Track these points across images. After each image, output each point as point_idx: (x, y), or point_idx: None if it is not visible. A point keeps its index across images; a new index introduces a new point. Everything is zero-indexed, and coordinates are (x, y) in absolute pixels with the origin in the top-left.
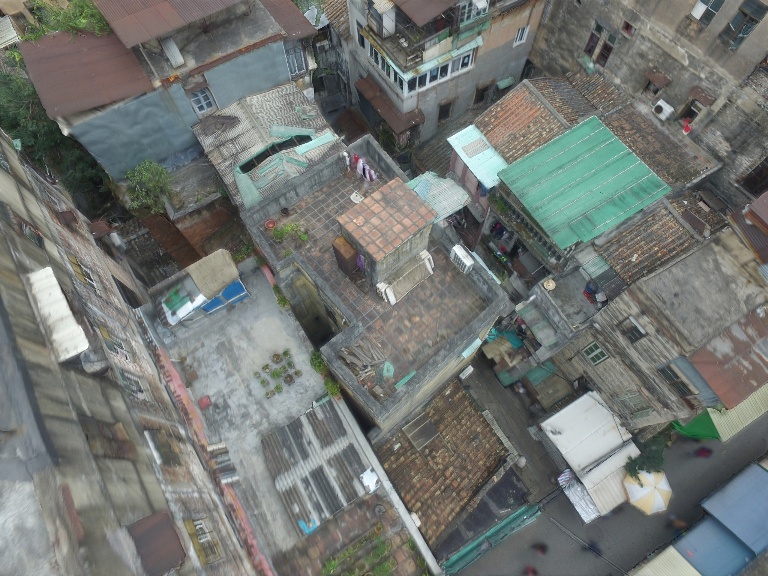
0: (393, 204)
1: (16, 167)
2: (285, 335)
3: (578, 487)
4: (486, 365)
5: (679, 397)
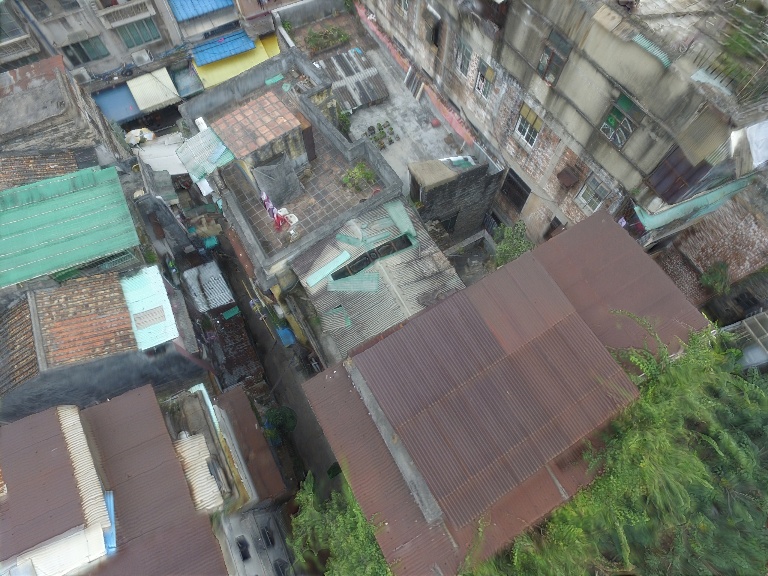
0: (248, 133)
1: (612, 159)
2: None
3: None
4: (226, 253)
5: (86, 96)
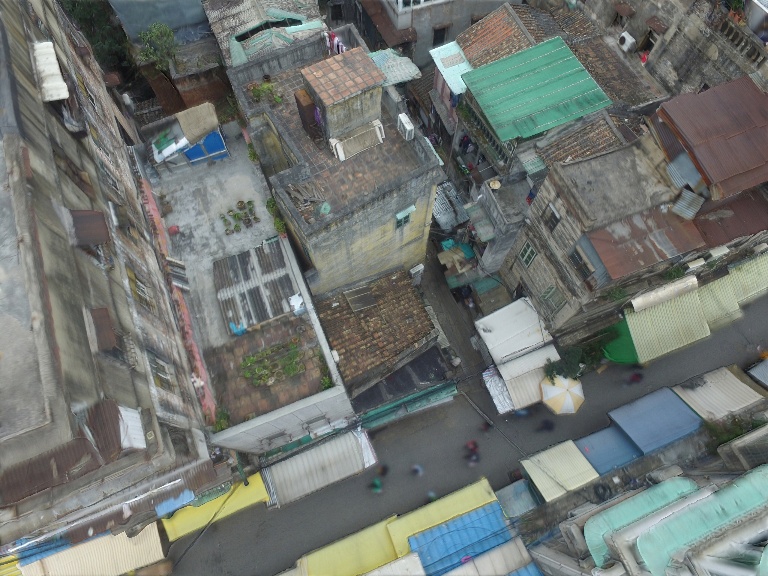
0: (350, 65)
1: None
2: (253, 190)
3: (499, 383)
4: (444, 280)
5: (582, 281)
